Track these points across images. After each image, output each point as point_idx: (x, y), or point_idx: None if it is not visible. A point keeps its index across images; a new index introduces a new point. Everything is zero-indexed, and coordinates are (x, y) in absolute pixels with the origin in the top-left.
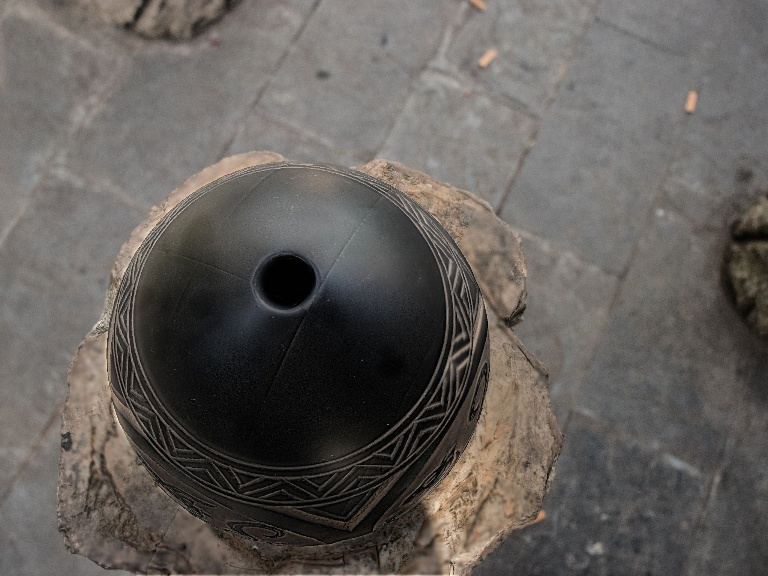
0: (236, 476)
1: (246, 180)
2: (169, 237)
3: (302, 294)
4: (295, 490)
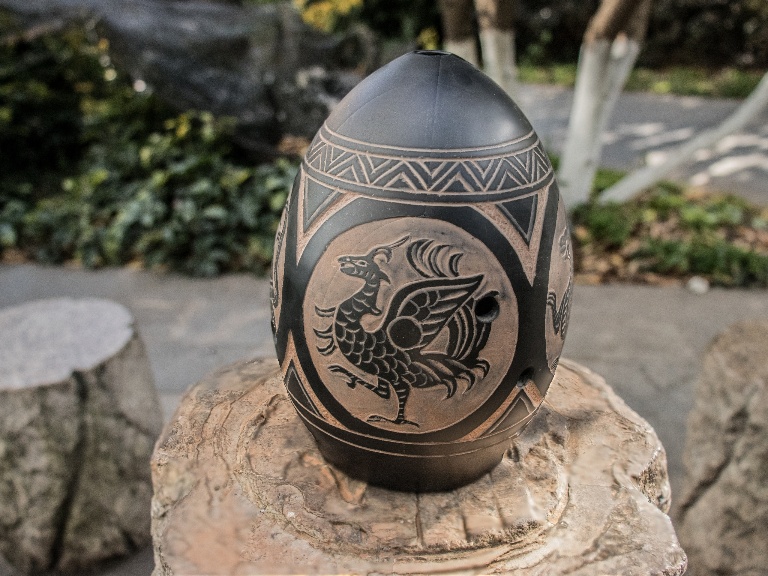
0: None
1: (358, 121)
2: (421, 127)
3: None
4: None
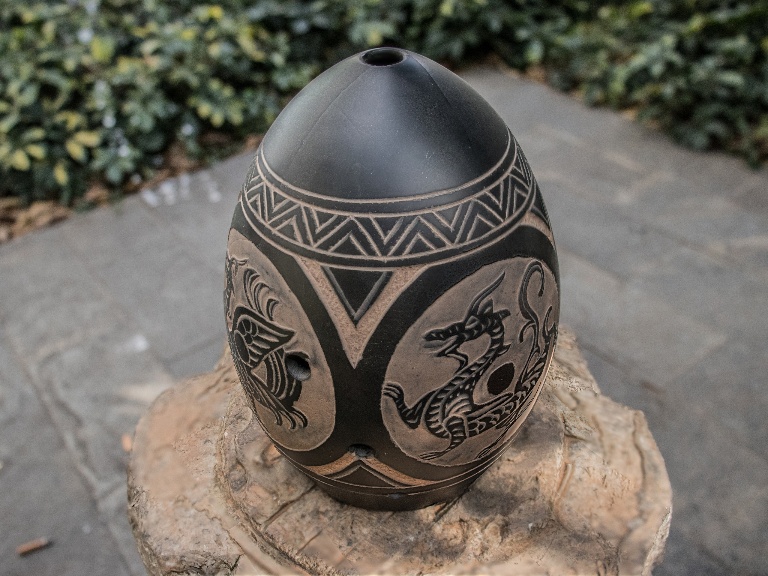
0: (493, 197)
1: None
2: (288, 151)
3: (395, 60)
4: (518, 183)
